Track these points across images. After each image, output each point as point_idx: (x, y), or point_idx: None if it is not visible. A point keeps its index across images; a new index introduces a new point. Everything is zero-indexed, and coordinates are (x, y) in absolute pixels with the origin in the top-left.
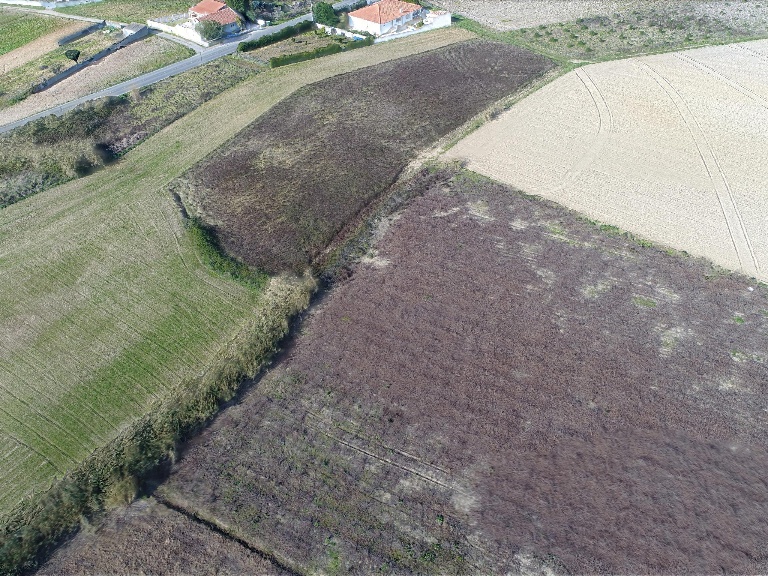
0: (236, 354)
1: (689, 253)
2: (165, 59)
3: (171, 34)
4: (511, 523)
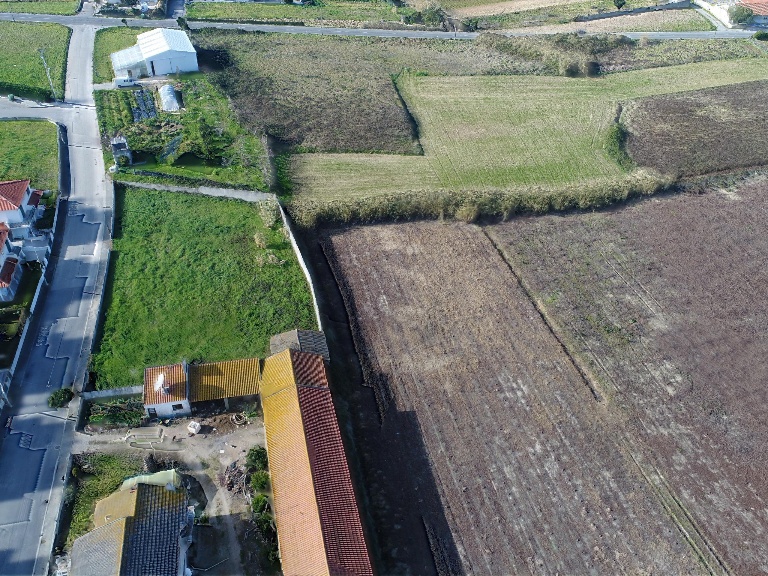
0: (581, 190)
1: None
2: (687, 26)
3: (707, 11)
4: (679, 348)
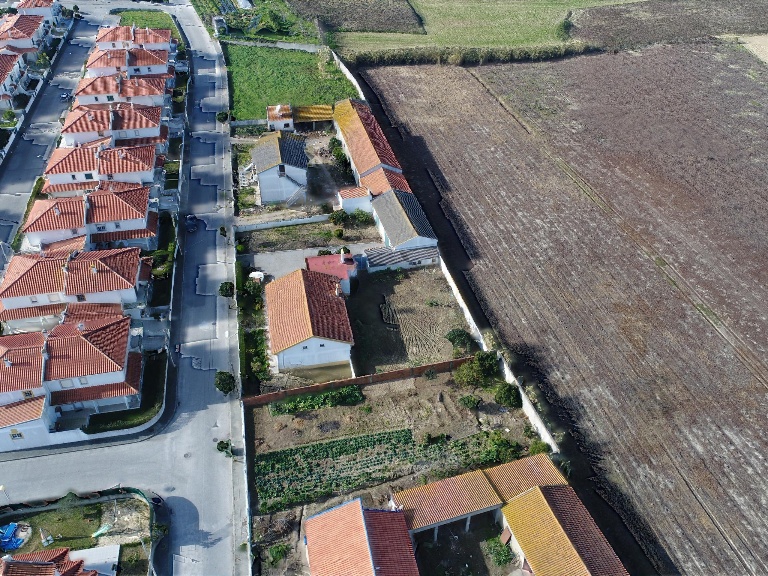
0: None
1: None
2: None
3: None
4: None
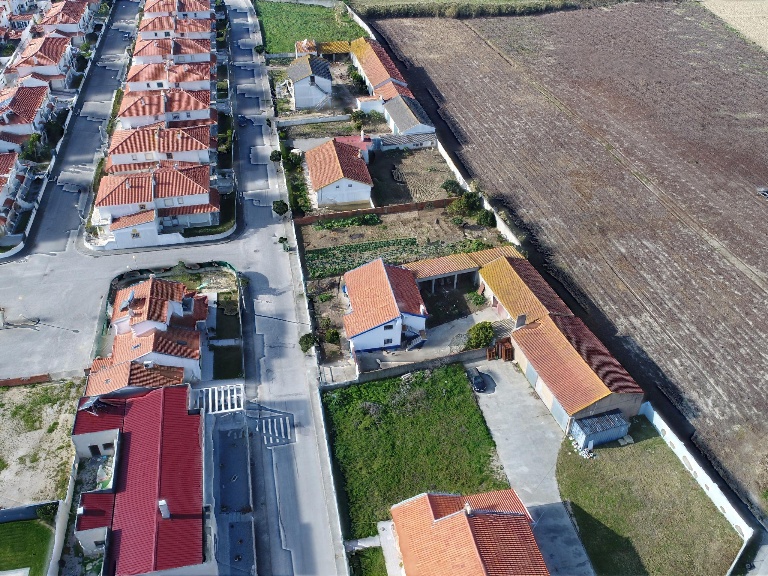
0: None
1: (757, 43)
2: None
3: None
4: None
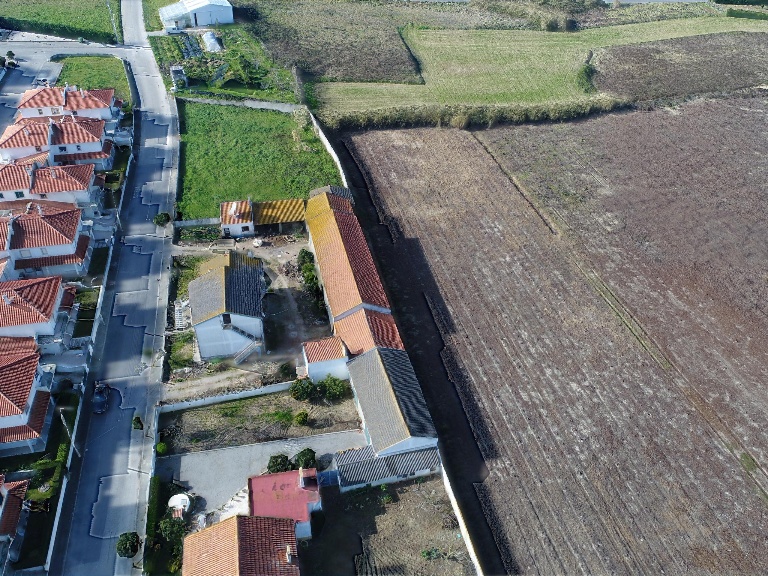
0: None
1: None
2: None
3: None
4: (618, 205)
